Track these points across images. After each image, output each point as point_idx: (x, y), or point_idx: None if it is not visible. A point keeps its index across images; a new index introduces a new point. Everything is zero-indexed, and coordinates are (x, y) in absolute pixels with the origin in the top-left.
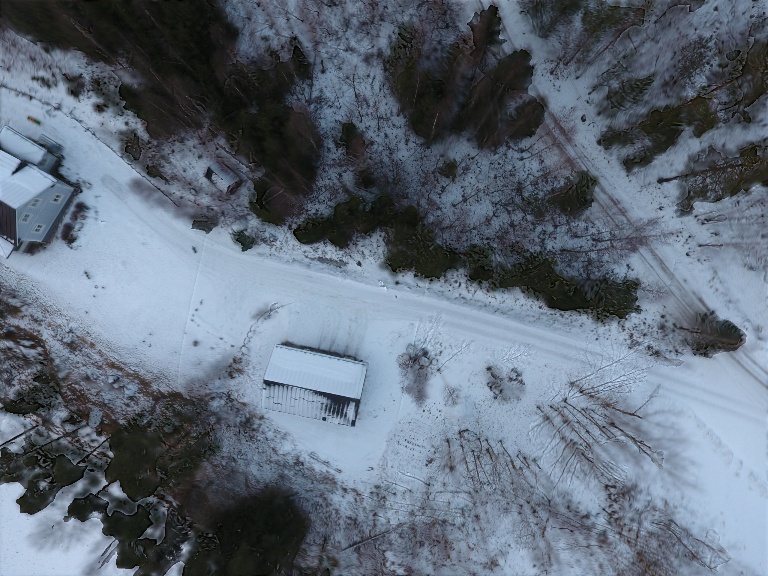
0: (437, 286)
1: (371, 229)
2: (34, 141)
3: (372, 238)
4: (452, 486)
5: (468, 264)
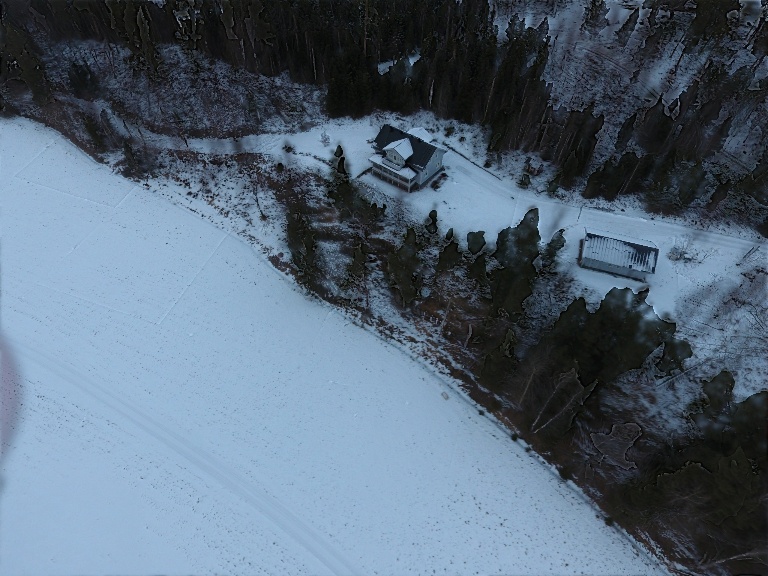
0: (680, 223)
1: (641, 173)
2: None
3: (629, 197)
4: (743, 333)
5: (698, 213)
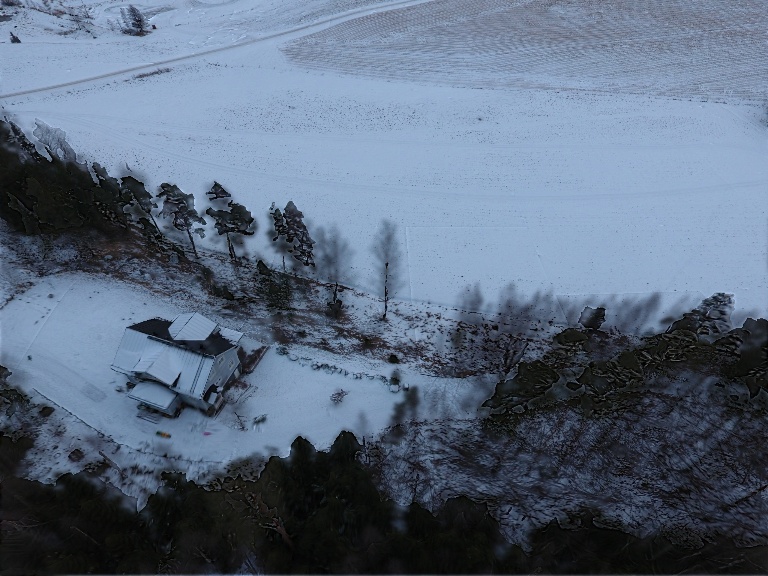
0: None
1: None
2: (165, 416)
3: None
4: None
5: None
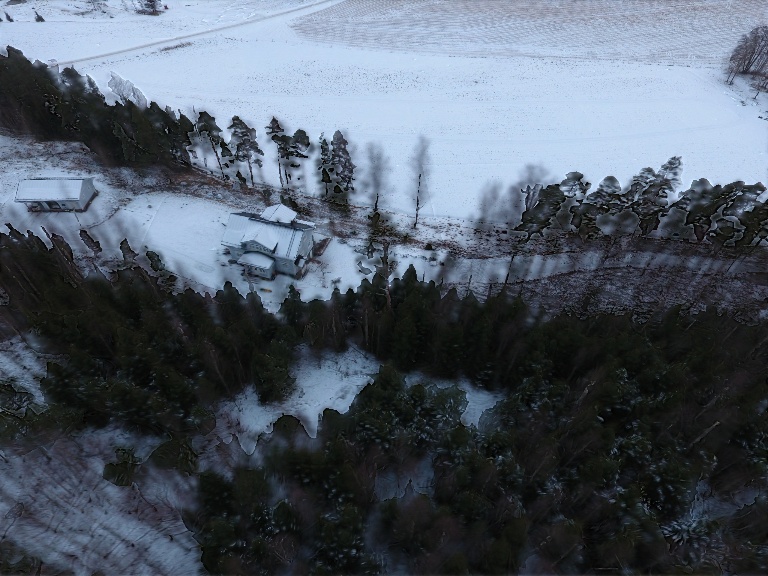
0: None
1: None
2: (264, 279)
3: None
4: None
5: None
